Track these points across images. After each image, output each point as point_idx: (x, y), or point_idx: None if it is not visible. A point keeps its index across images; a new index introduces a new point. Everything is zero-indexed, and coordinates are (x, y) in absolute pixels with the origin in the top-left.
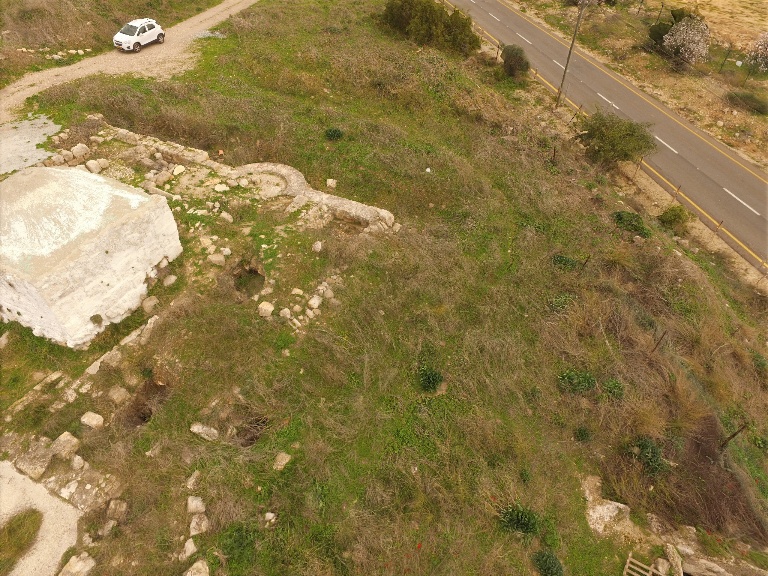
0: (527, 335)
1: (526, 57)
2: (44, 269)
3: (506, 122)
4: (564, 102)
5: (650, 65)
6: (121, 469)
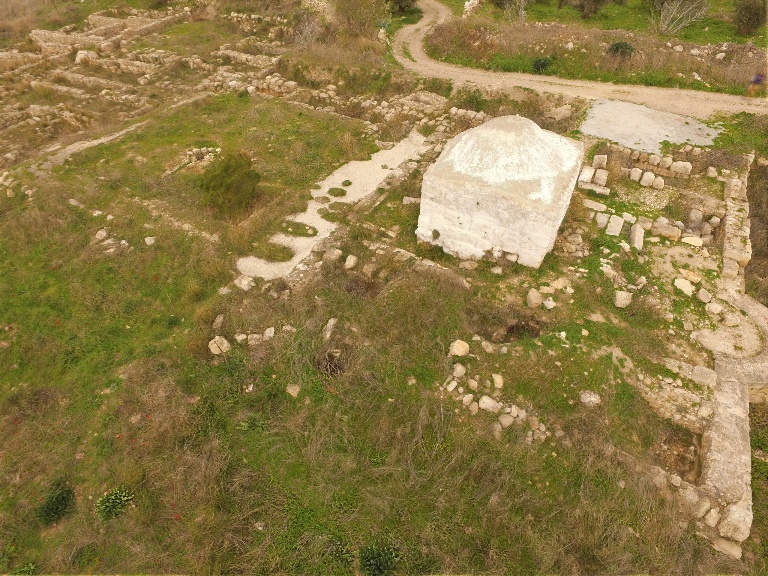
0: None
1: None
2: (440, 174)
3: None
4: None
5: None
6: None
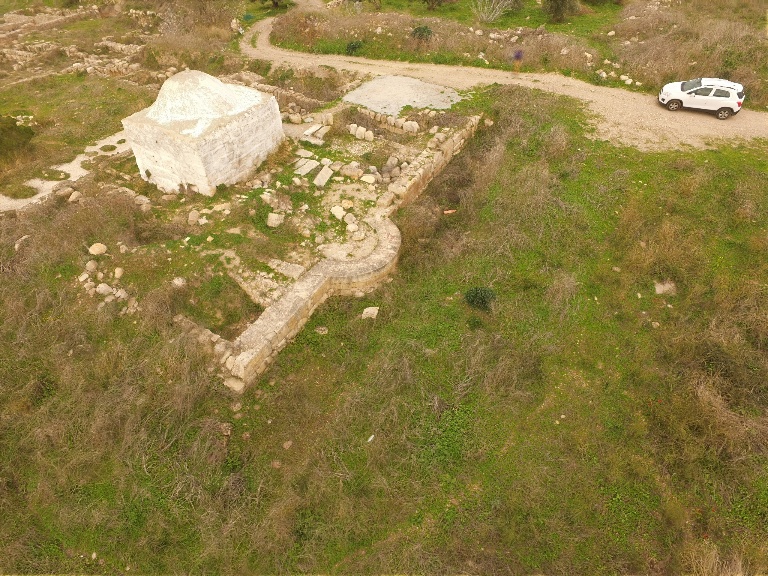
0: None
1: None
2: (134, 119)
3: None
4: None
5: None
6: None
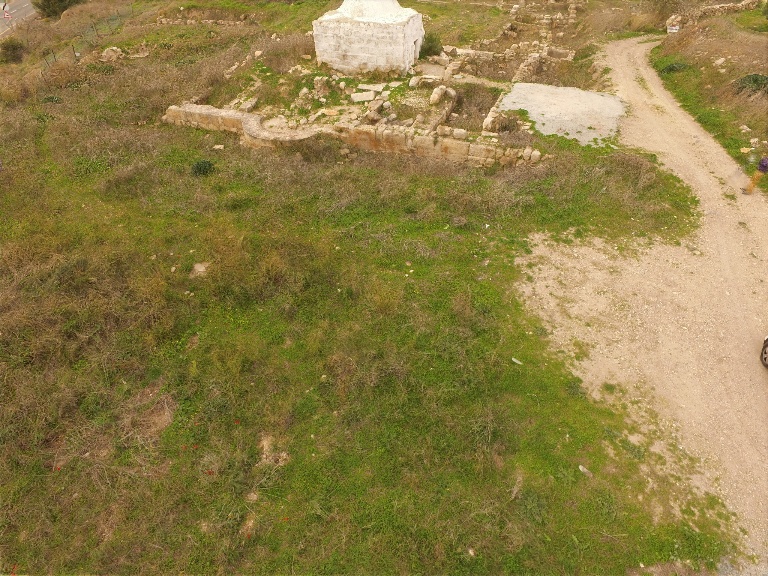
0: None
1: None
2: None
3: None
4: None
5: None
6: None
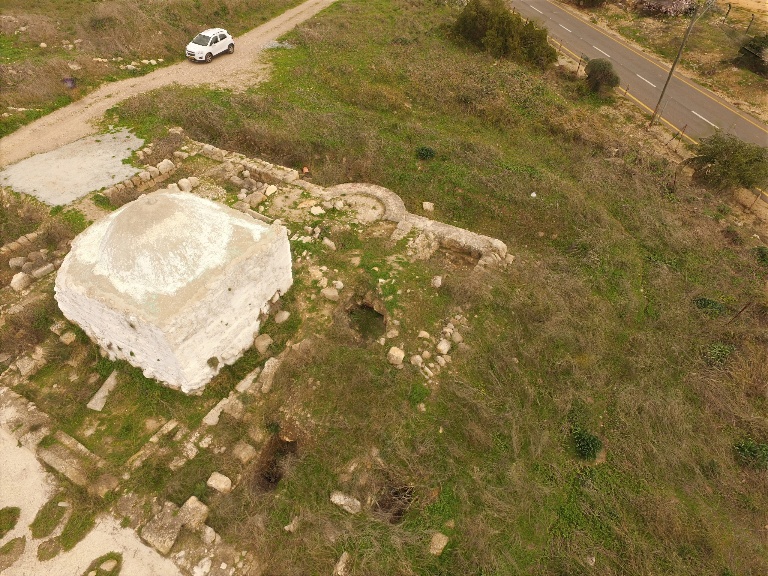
0: (685, 393)
1: (615, 72)
2: (171, 310)
3: (608, 143)
4: (658, 120)
5: (743, 81)
6: (259, 546)
